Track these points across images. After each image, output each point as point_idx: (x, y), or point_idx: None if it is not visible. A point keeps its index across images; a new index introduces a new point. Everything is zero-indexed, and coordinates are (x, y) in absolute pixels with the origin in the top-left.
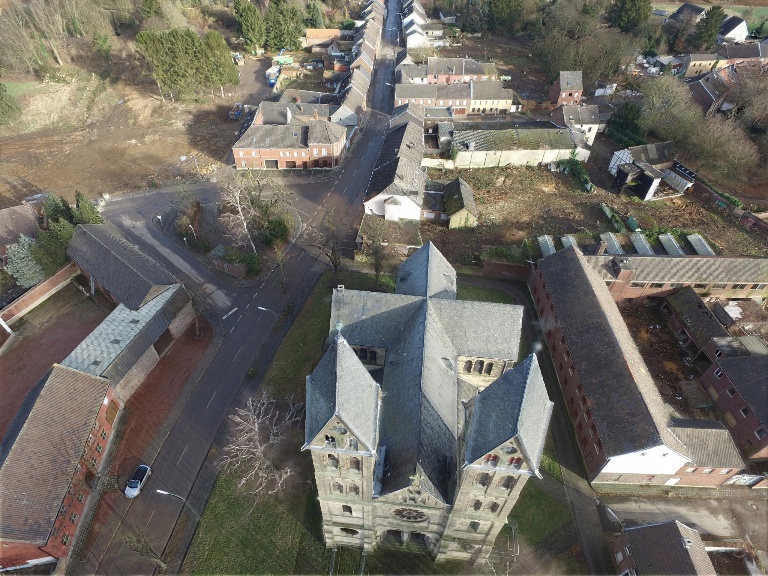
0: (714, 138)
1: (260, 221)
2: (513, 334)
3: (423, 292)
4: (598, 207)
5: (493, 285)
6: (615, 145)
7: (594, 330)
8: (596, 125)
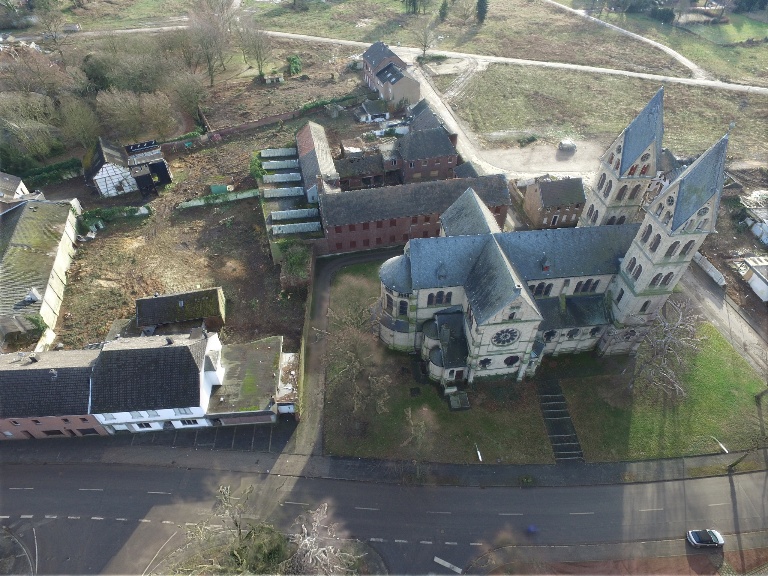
0: (131, 107)
1: (256, 574)
2: (483, 204)
3: (483, 239)
4: (182, 210)
5: (326, 281)
6: (45, 188)
7: (418, 194)
8: (20, 183)
